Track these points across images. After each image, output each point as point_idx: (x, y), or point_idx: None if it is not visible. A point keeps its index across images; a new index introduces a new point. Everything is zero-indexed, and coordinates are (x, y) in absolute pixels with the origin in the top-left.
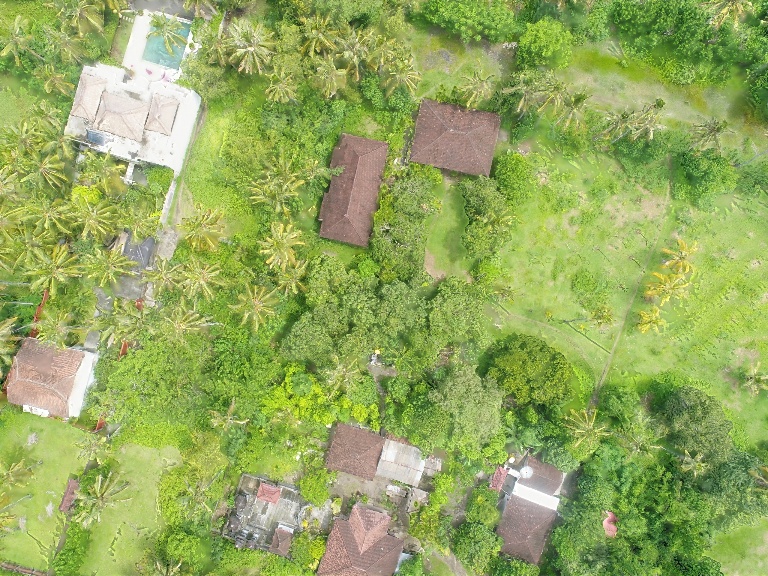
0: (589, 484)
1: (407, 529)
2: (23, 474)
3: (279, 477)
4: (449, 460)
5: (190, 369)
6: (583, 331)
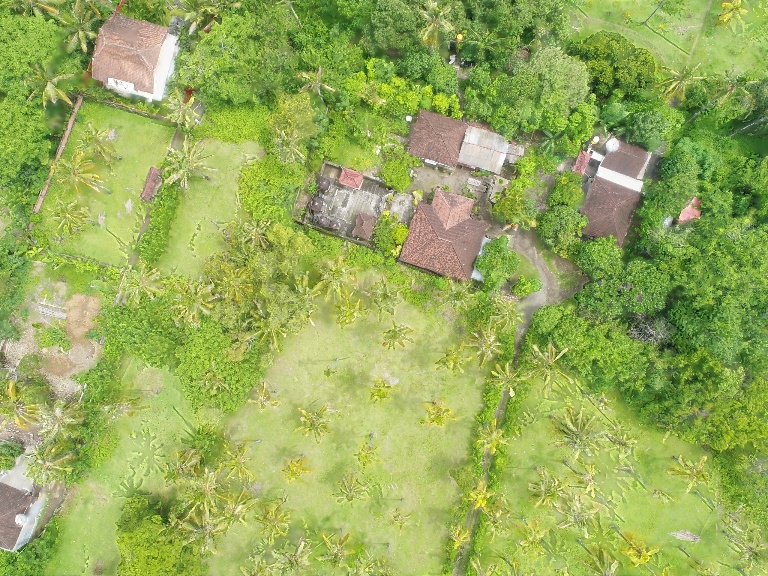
0: (675, 159)
1: (488, 223)
2: (109, 144)
3: (359, 171)
4: (529, 155)
5: (277, 33)
6: (662, 32)
